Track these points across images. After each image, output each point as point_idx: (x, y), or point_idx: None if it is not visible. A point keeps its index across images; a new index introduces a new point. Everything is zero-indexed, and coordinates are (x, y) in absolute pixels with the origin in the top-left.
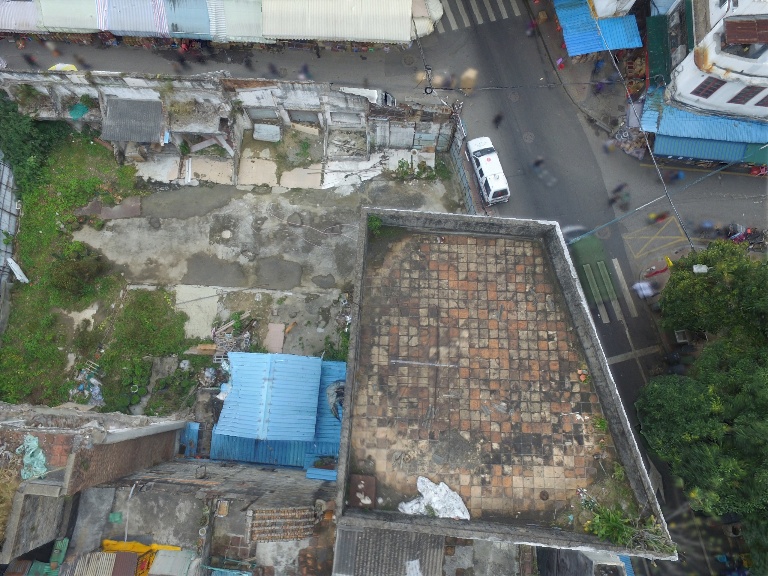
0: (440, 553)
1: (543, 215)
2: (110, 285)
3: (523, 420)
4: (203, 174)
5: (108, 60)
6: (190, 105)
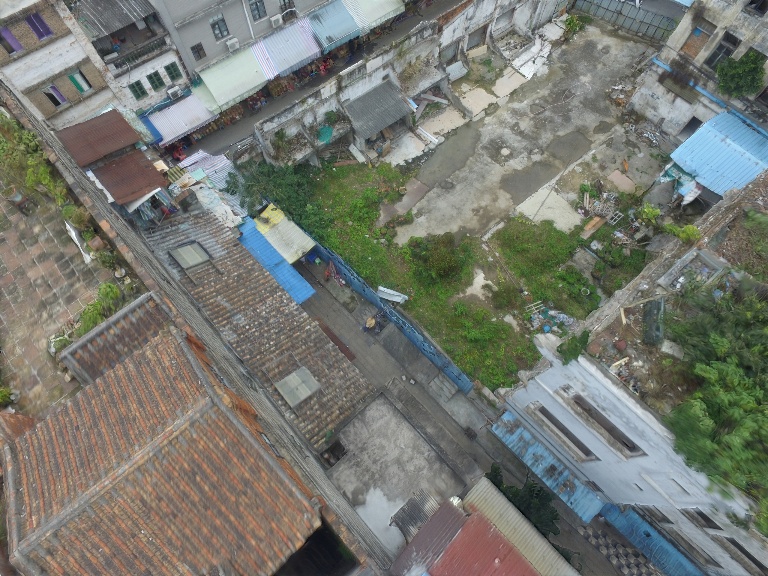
0: None
1: (665, 2)
2: None
3: None
4: (440, 130)
5: None
6: (406, 71)
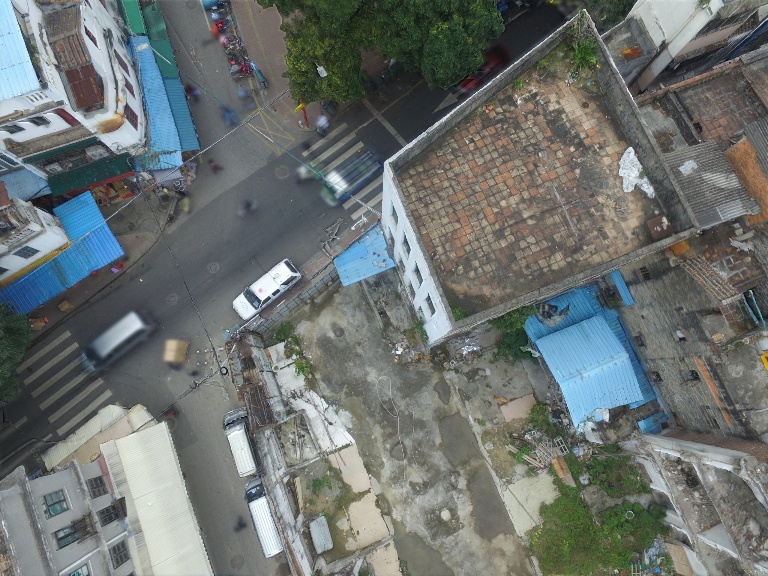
0: (666, 156)
1: (288, 226)
2: None
3: (543, 137)
4: None
5: None
6: None
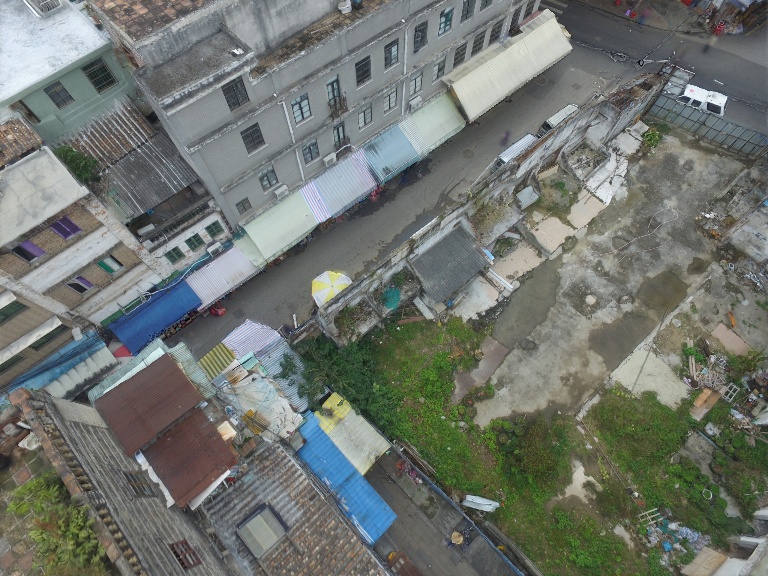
0: None
1: (746, 104)
2: (564, 431)
3: None
4: (514, 272)
5: (318, 256)
6: (479, 213)
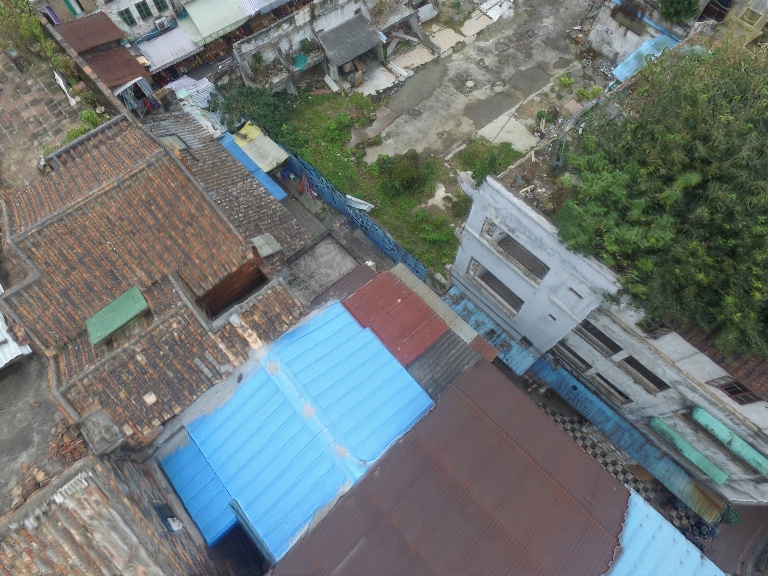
0: None
1: None
2: (434, 165)
3: None
4: (410, 64)
5: None
6: (378, 7)
